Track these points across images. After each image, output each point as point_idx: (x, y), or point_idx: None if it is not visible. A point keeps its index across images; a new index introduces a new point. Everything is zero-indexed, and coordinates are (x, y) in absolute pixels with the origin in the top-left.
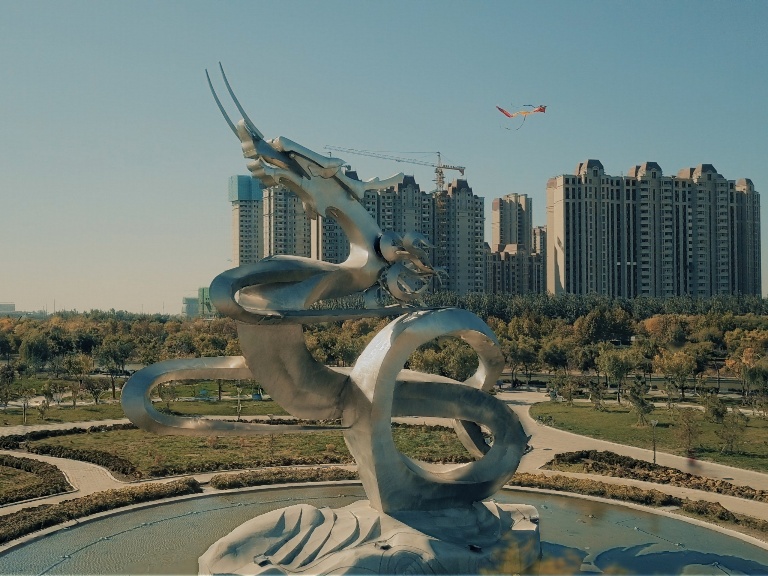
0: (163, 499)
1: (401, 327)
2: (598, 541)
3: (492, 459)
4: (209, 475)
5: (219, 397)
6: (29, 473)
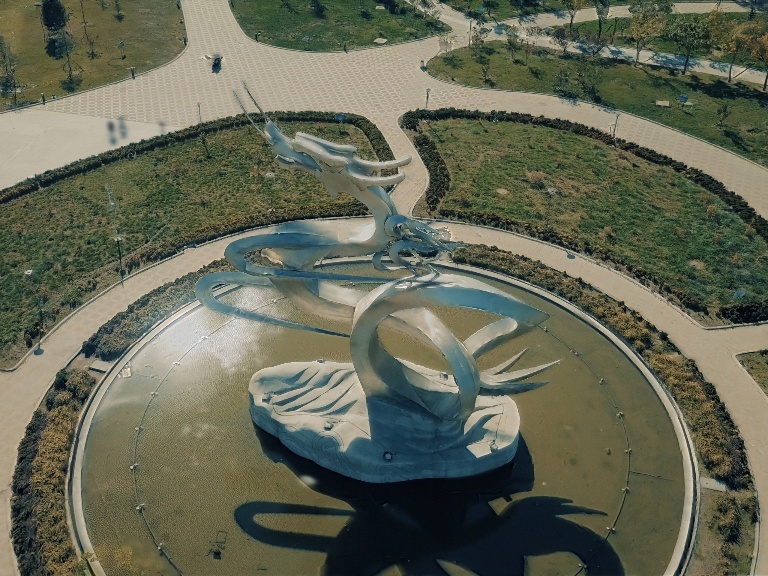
0: None
1: (388, 292)
2: (569, 482)
3: (453, 401)
4: (474, 230)
5: (684, 69)
6: (380, 174)
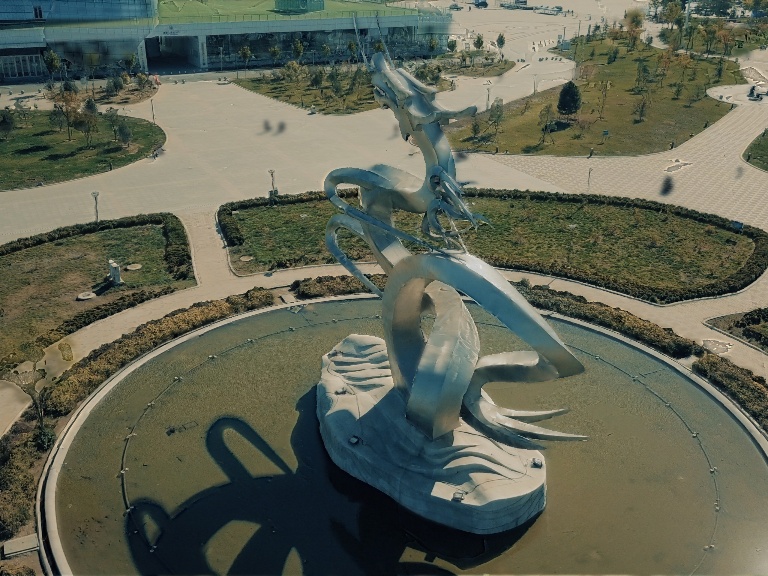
0: (631, 340)
1: None
2: None
3: None
4: (763, 359)
5: None
6: None
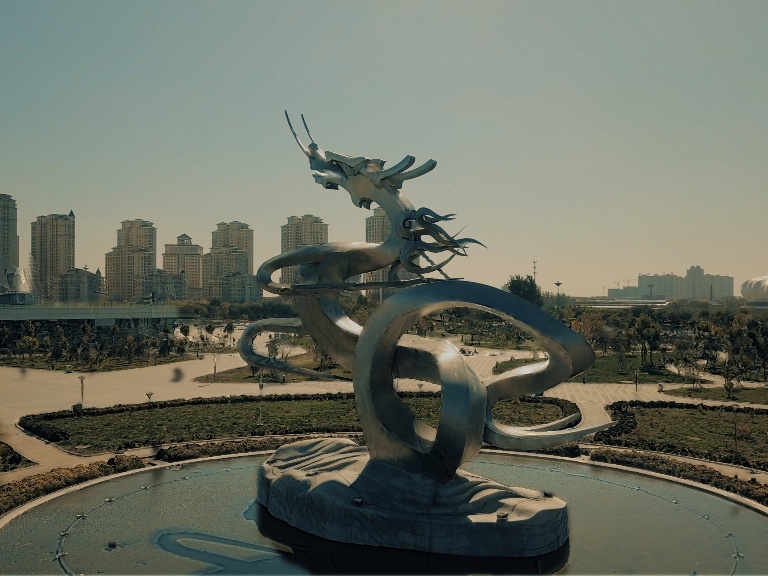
0: (524, 452)
1: None
2: None
3: None
4: None
5: None
6: None
